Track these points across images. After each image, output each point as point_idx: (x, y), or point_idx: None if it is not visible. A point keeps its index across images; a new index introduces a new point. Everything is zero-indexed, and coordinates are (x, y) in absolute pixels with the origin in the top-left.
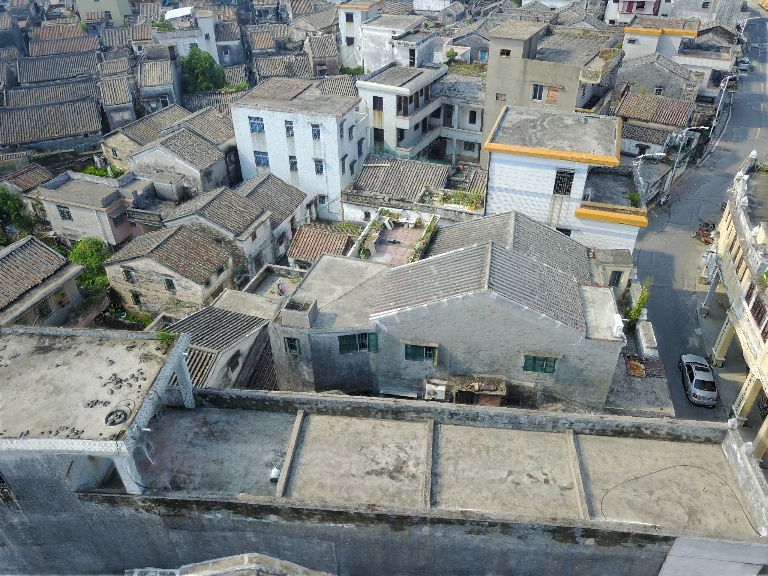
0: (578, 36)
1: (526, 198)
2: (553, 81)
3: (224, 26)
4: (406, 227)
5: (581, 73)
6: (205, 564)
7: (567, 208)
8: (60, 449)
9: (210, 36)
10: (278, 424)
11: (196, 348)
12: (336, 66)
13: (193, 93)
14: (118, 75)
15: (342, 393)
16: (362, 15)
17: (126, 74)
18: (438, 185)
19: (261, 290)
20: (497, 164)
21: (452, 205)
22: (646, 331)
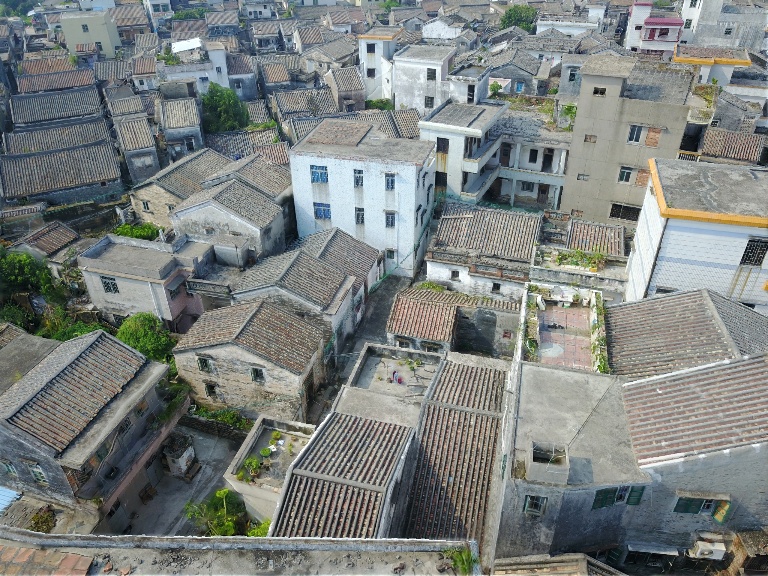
0: (654, 70)
1: (704, 269)
2: (655, 122)
3: (235, 58)
4: (560, 306)
5: (690, 113)
6: None
7: (755, 280)
8: None
9: (222, 69)
10: None
11: (354, 485)
12: (362, 100)
13: (216, 133)
14: (137, 116)
15: (589, 558)
16: (384, 45)
17: (146, 115)
18: (532, 238)
19: (366, 376)
20: (673, 231)
21: (570, 266)
22: None
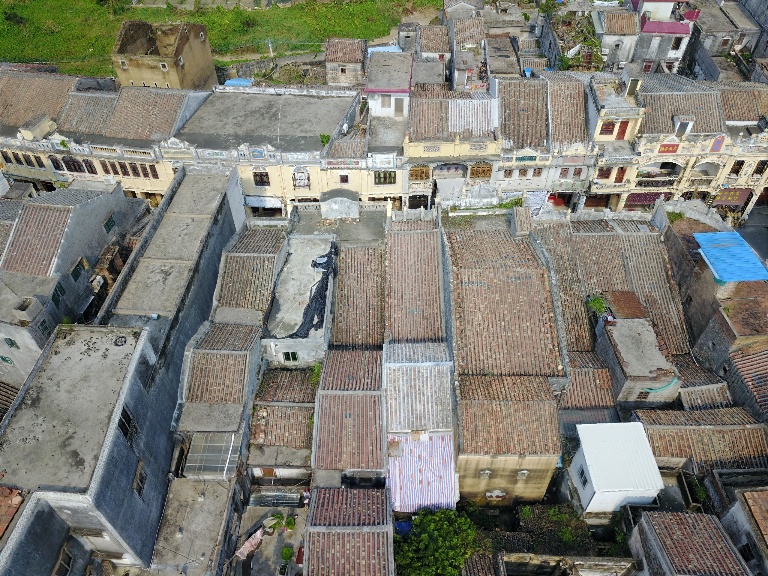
0: None
1: None
2: None
3: None
4: None
5: None
6: (181, 380)
7: None
8: (138, 357)
9: None
10: (117, 323)
11: None
12: None
13: None
14: None
15: None
16: None
17: None
18: None
19: None
20: None
21: None
22: None
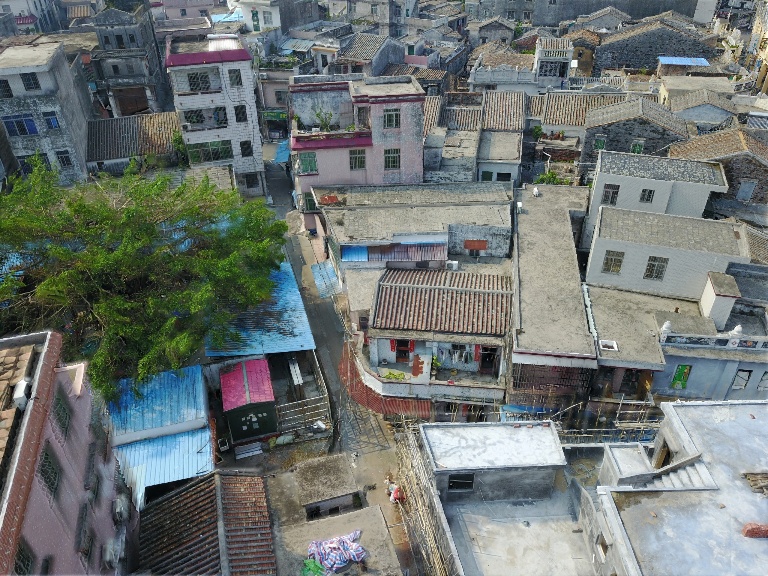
0: None
1: None
2: None
3: None
4: None
5: None
6: None
7: None
8: None
9: None
10: None
11: None
12: None
13: None
14: None
15: None
16: None
17: None
18: None
19: None
20: None
21: None
22: None
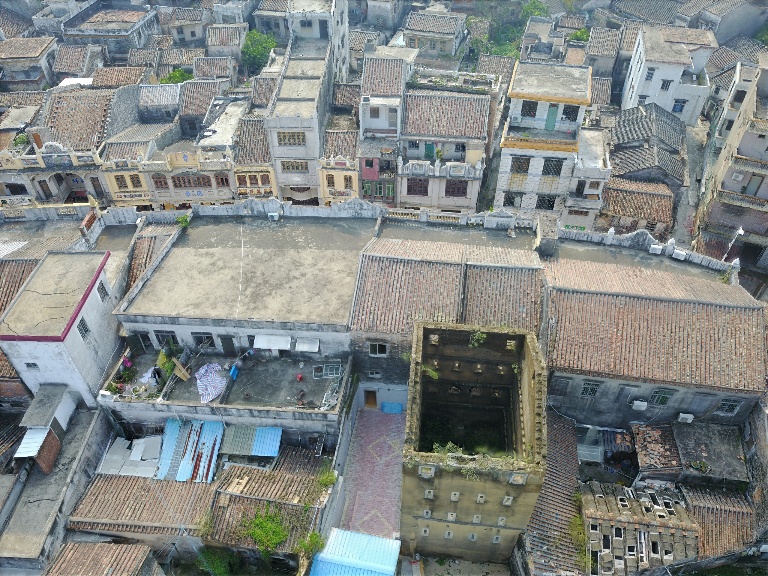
0: None
1: None
2: None
3: None
4: None
5: None
6: None
7: None
8: None
9: None
10: None
11: None
12: None
13: None
14: None
15: None
16: None
17: None
18: None
19: None
20: None
21: None
22: (420, 161)
